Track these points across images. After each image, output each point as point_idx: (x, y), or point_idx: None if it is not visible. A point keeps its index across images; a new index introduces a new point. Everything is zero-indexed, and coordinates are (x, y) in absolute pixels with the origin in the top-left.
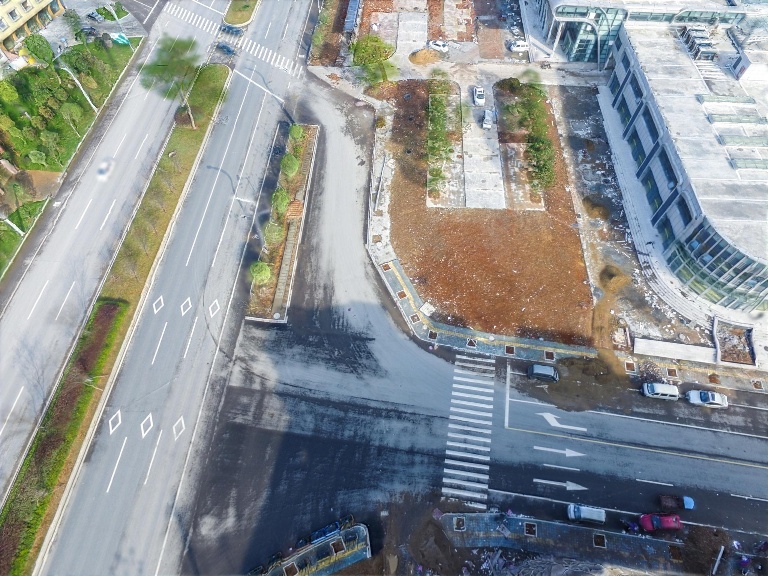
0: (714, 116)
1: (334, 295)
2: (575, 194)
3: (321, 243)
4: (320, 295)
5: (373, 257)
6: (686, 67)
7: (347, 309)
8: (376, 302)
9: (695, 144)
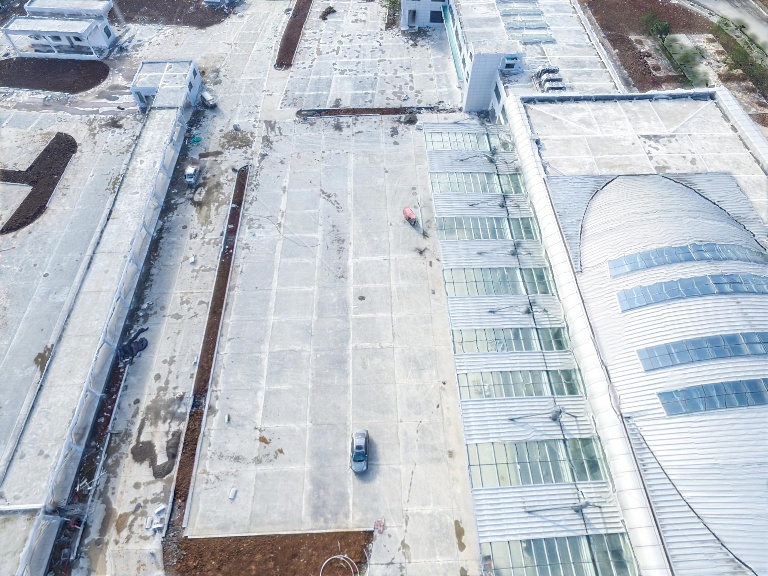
0: (544, 25)
1: (729, 4)
2: (610, 48)
3: (760, 22)
4: (737, 4)
5: (722, 18)
6: (563, 67)
7: (717, 0)
8: (704, 3)
9: (560, 10)
